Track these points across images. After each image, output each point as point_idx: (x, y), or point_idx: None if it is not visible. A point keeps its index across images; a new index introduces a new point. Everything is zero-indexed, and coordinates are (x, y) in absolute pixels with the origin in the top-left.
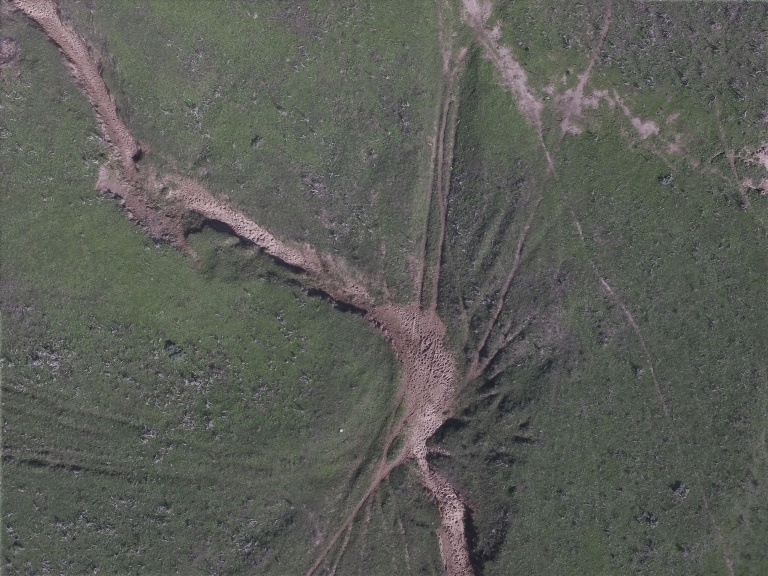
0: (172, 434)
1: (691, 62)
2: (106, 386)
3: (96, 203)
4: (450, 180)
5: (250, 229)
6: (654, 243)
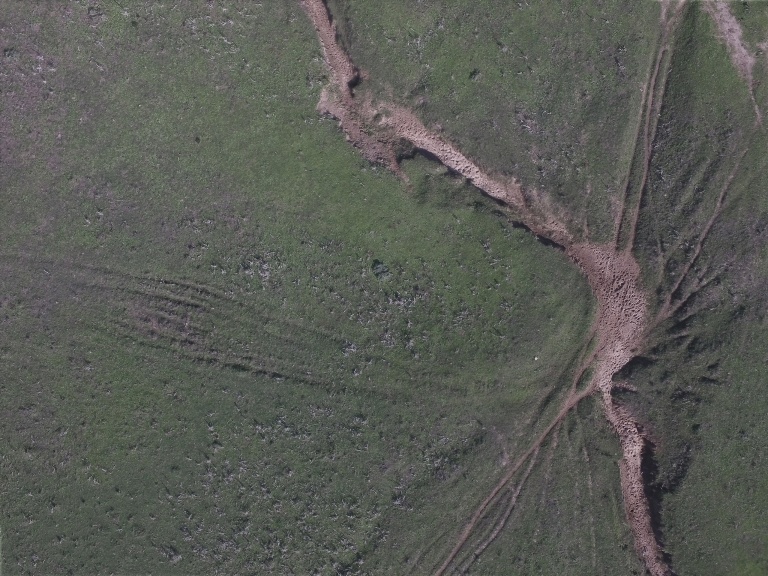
0: (372, 350)
1: None
2: (312, 299)
3: (317, 122)
4: (657, 126)
5: (457, 160)
6: None
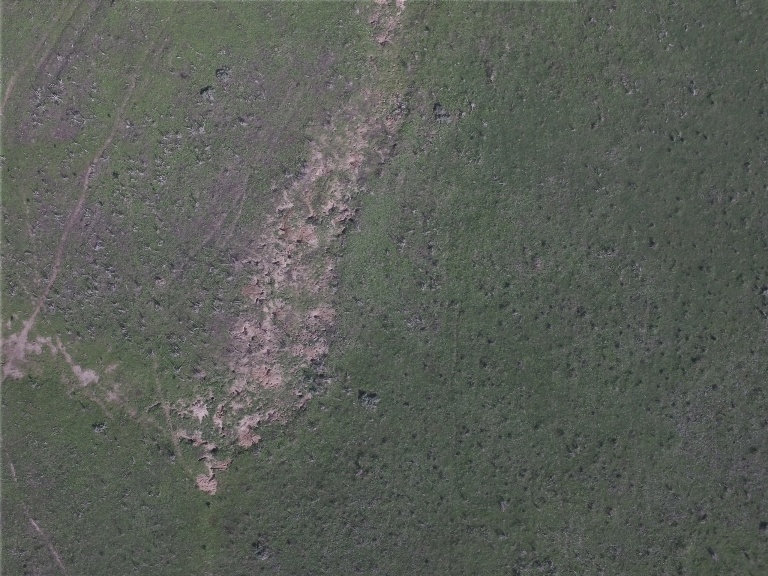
0: None
1: (133, 315)
2: None
3: None
4: None
5: None
6: (85, 488)
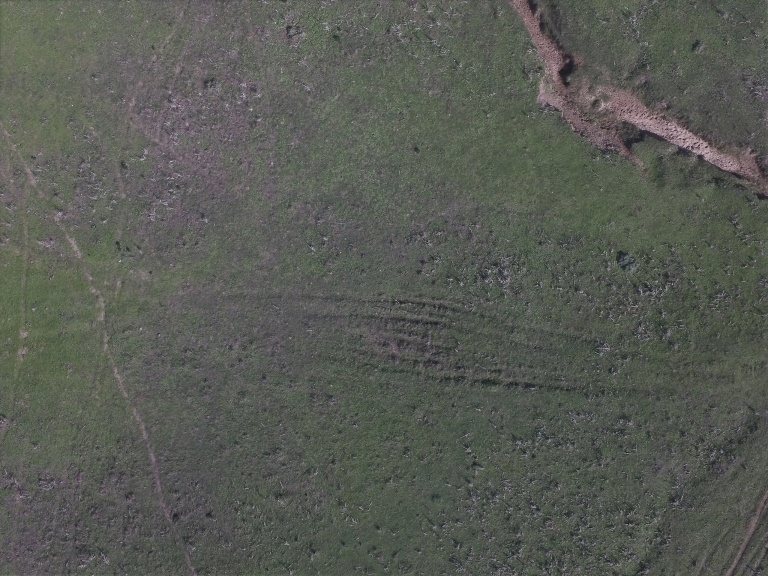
0: (626, 346)
1: None
2: (558, 301)
3: (540, 116)
4: None
5: (684, 138)
6: None
